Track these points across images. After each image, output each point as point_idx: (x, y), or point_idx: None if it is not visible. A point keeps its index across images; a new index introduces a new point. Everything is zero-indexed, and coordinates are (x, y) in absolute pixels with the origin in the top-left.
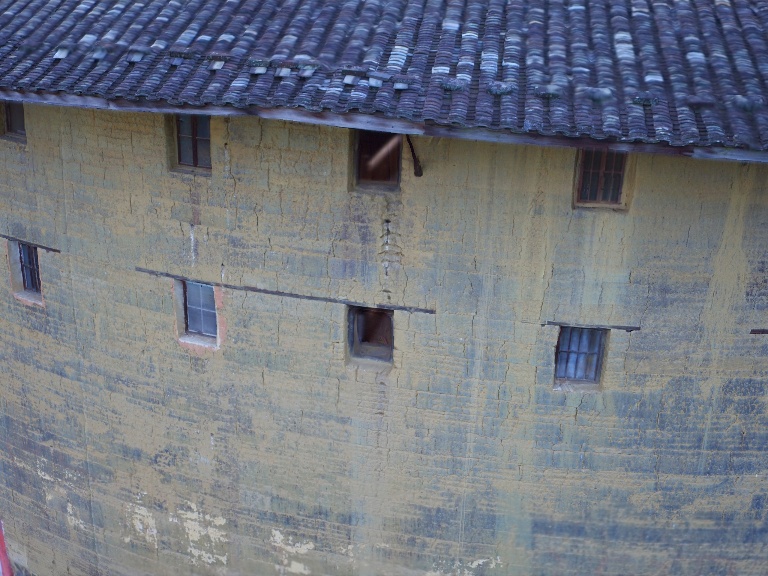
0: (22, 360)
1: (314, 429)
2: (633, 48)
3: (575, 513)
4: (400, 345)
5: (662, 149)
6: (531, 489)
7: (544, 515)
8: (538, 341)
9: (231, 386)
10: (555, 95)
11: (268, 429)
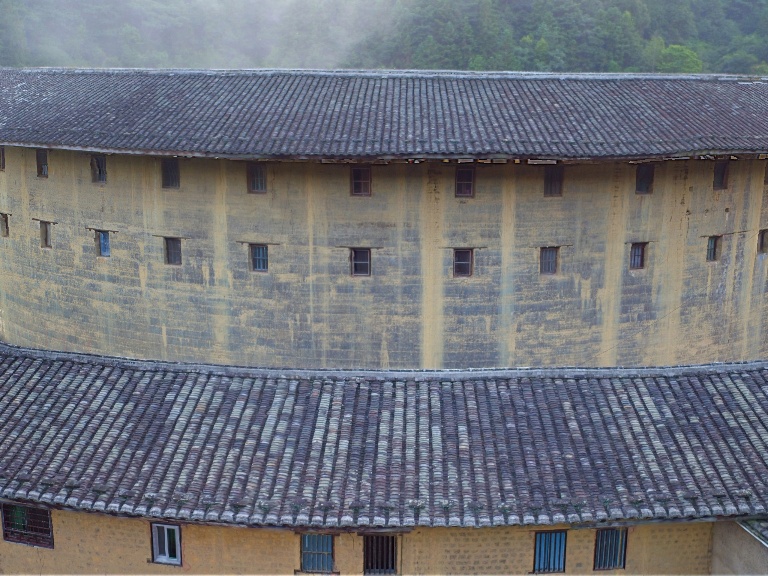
0: None
1: None
2: None
3: None
4: None
5: None
6: None
7: None
8: None
9: None
10: None
11: None
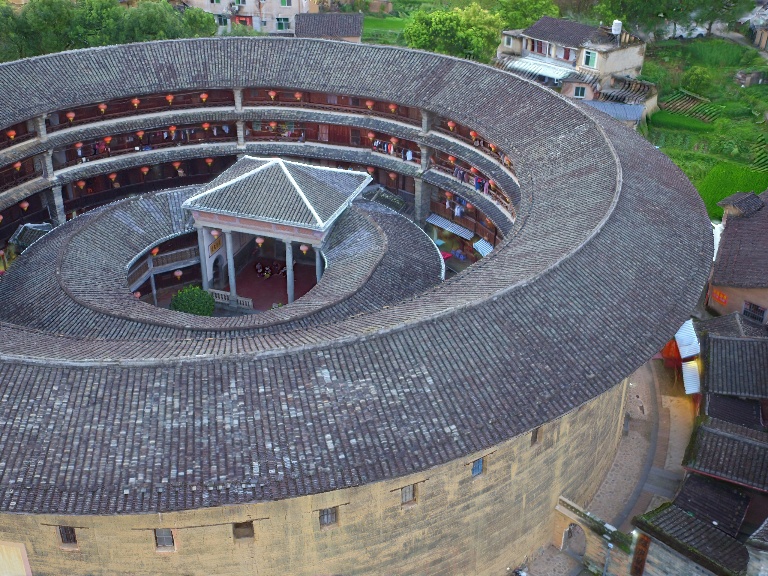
0: (65, 573)
1: (224, 571)
2: (333, 442)
3: (337, 571)
4: (257, 532)
5: (349, 487)
6: (318, 568)
7: (325, 575)
8: (312, 517)
9: (183, 564)
10: (313, 475)
11: (203, 575)
